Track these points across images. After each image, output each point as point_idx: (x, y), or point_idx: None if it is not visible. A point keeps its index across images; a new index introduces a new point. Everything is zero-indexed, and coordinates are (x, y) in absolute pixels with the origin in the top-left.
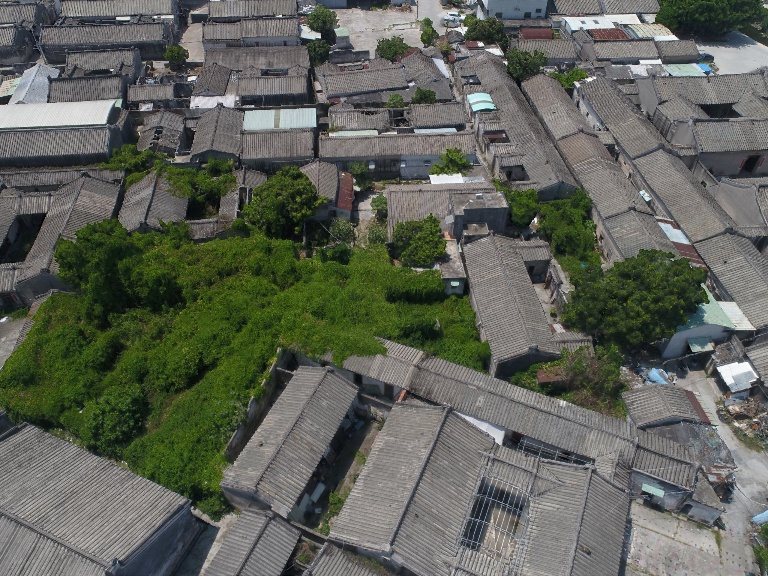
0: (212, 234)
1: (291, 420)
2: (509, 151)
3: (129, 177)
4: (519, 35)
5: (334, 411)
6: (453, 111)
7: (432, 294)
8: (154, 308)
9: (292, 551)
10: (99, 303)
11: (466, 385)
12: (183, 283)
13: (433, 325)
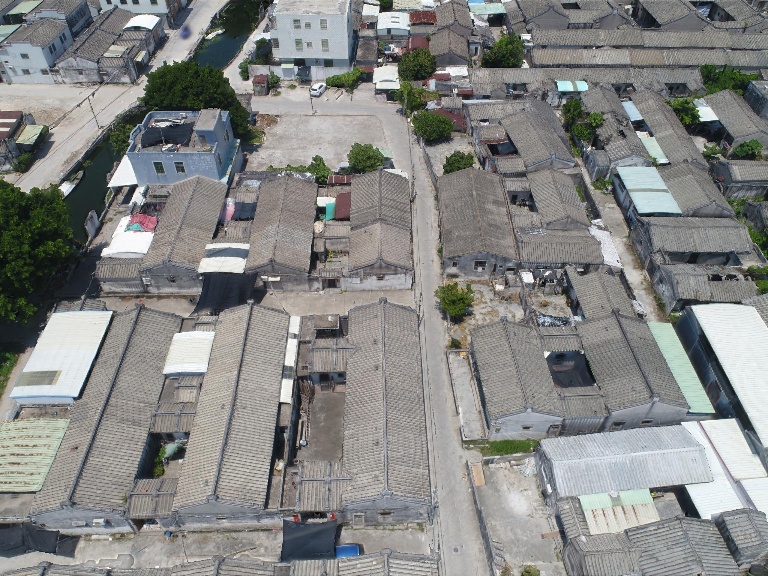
0: None
1: None
2: None
3: None
4: None
5: None
6: (609, 94)
7: None
8: None
9: None
10: None
11: None
12: None
13: None
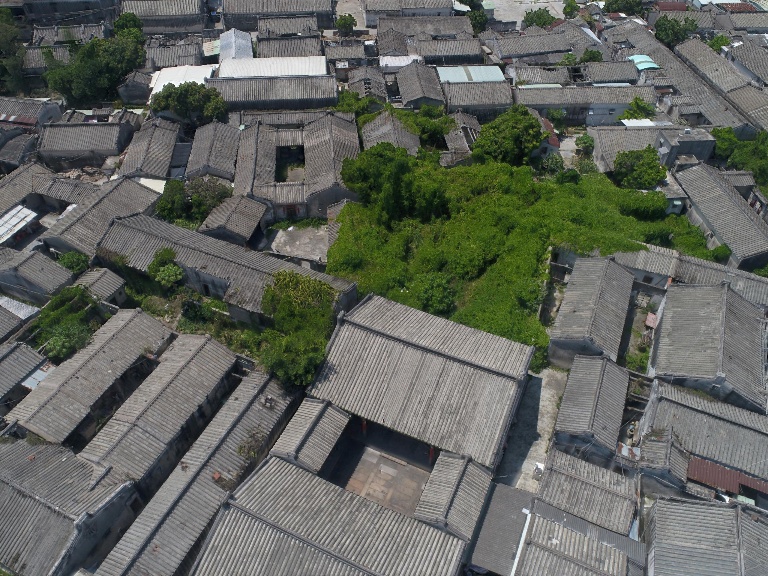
0: (452, 162)
1: (594, 293)
2: (684, 102)
3: (361, 118)
4: (653, 8)
5: (623, 289)
6: (625, 68)
7: (657, 212)
8: (422, 219)
9: (627, 385)
10: (386, 211)
11: (725, 273)
12: (450, 197)
13: (671, 233)
